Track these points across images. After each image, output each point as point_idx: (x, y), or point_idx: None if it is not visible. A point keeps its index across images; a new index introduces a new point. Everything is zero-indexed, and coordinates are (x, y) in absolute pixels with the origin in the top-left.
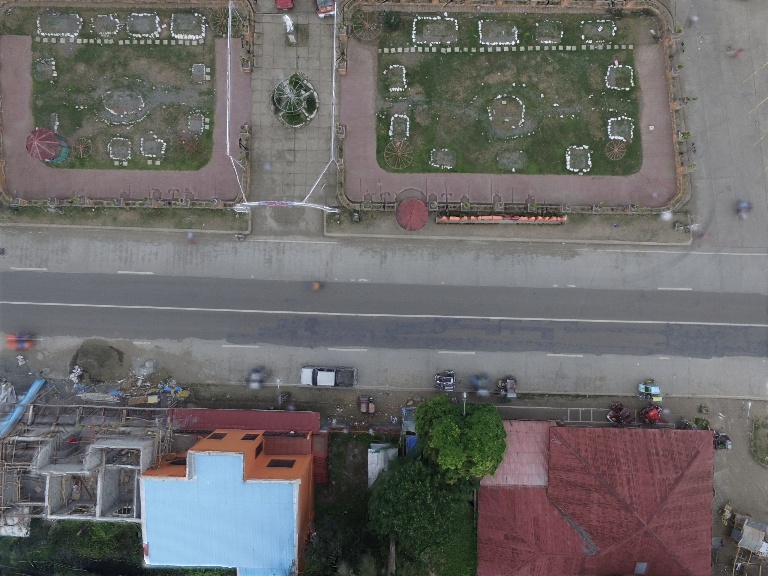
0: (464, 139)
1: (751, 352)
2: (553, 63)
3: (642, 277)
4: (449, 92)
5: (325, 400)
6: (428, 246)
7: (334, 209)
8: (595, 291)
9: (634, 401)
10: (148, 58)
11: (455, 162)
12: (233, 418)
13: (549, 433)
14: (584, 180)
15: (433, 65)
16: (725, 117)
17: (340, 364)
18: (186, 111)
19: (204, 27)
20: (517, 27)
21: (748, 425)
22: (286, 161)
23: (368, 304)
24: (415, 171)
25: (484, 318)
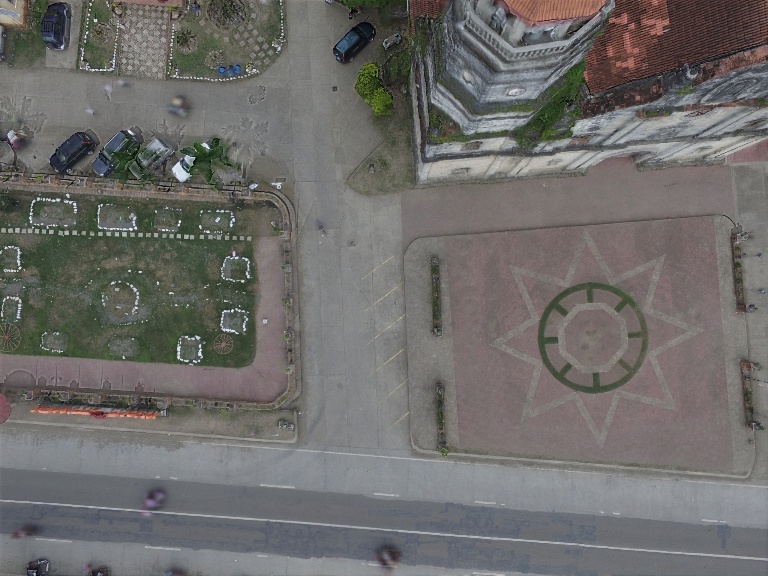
0: (77, 323)
1: (350, 554)
2: (171, 251)
3: (245, 473)
4: (65, 275)
5: None
6: (33, 430)
7: None
8: (197, 484)
9: None
10: None
11: (67, 346)
12: None
13: None
14: (195, 370)
15: (50, 247)
16: (341, 313)
17: None
18: None
19: None
20: (137, 213)
21: None
22: None
23: None
24: (26, 353)
25: (83, 507)
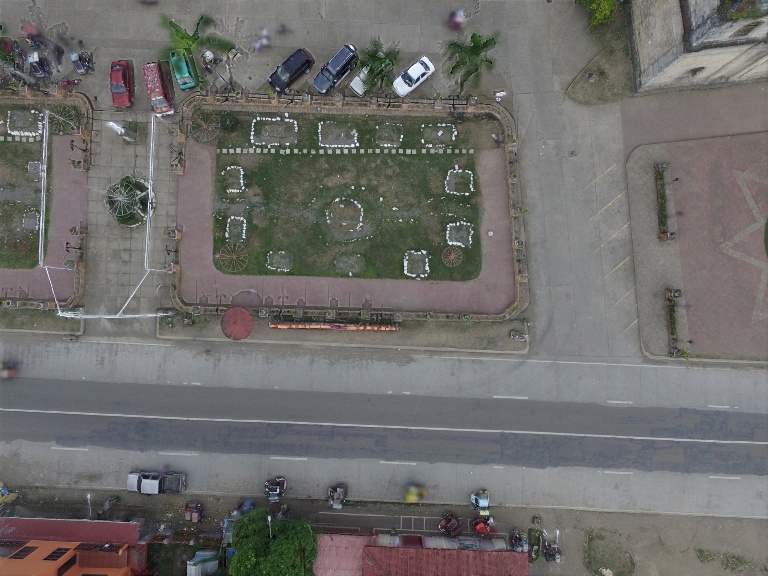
0: (302, 242)
1: (586, 462)
2: (393, 166)
3: (478, 385)
4: (287, 194)
5: (155, 505)
6: (262, 350)
7: (167, 312)
8: (430, 398)
9: (467, 510)
10: None
11: (292, 265)
12: (49, 529)
13: (362, 553)
14: (422, 285)
15: (272, 166)
16: (566, 223)
17: (170, 469)
18: (21, 209)
19: (41, 124)
20: (357, 129)
21: (582, 536)
22: (121, 261)
23: (200, 408)
24: (252, 273)
25: (317, 424)
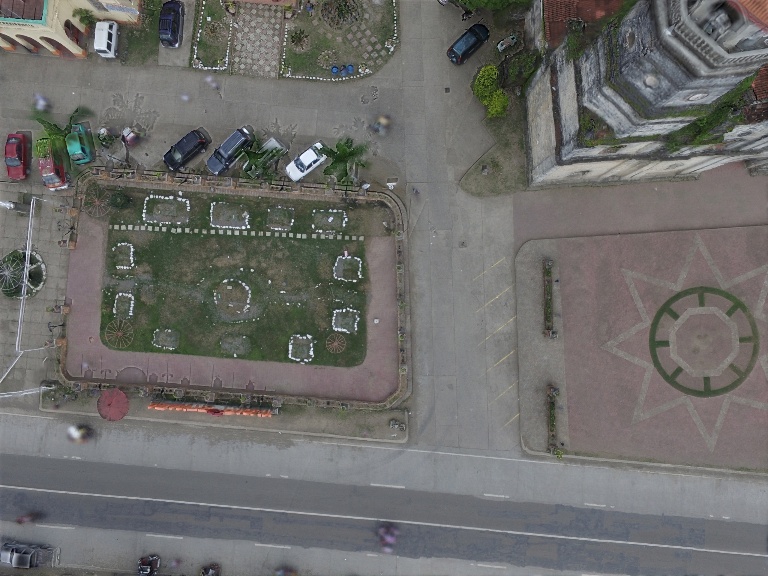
0: (189, 321)
1: (460, 554)
2: (283, 250)
3: (356, 472)
4: (177, 272)
5: (30, 575)
6: (144, 427)
7: (50, 385)
8: (308, 483)
9: None
10: None
11: (178, 343)
12: None
13: None
14: (306, 369)
15: (162, 244)
16: (452, 314)
17: (47, 541)
18: None
19: None
20: (249, 211)
21: None
22: (9, 332)
23: (79, 482)
24: (137, 350)
25: (194, 504)
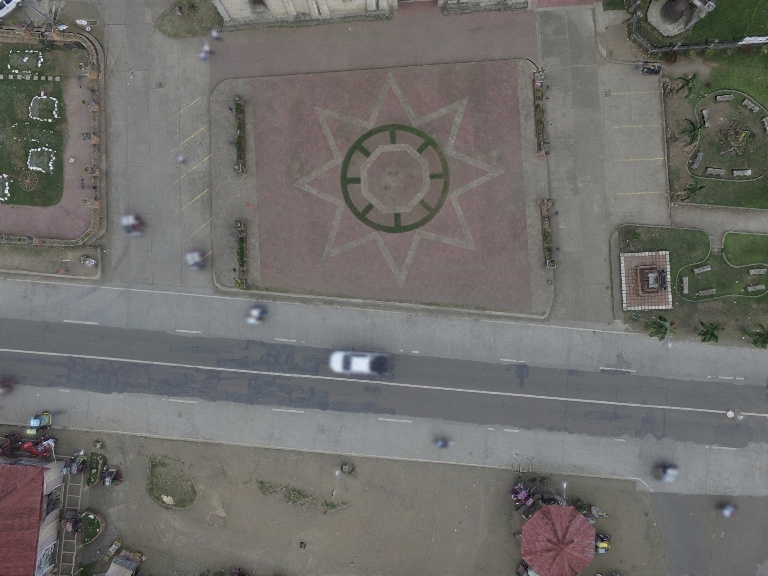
0: None
1: (152, 390)
2: None
3: (49, 308)
4: None
5: None
6: None
7: None
8: (1, 320)
9: None
10: None
11: None
12: None
13: None
14: (3, 208)
15: None
16: (148, 154)
17: None
18: None
19: None
20: None
21: (147, 462)
22: None
23: None
24: None
25: None
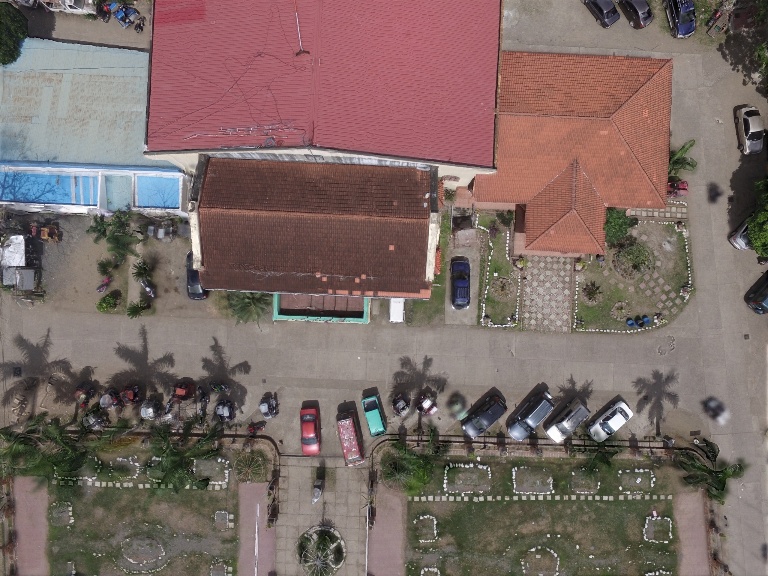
0: None
1: None
2: (589, 512)
3: None
4: (481, 542)
5: None
6: None
7: None
8: None
9: None
10: (169, 502)
11: None
12: None
13: None
14: None
15: (465, 514)
16: (766, 570)
17: None
18: (208, 560)
19: (227, 472)
20: (552, 475)
21: None
22: None
23: None
24: None
25: None
